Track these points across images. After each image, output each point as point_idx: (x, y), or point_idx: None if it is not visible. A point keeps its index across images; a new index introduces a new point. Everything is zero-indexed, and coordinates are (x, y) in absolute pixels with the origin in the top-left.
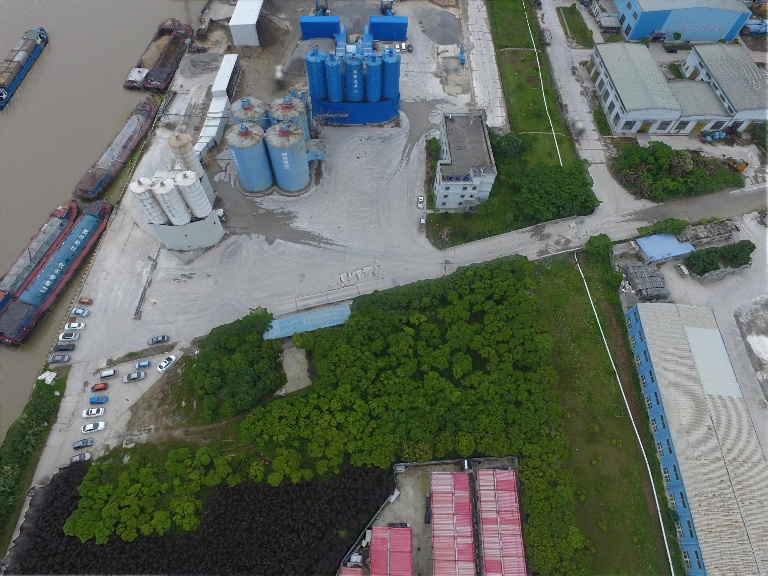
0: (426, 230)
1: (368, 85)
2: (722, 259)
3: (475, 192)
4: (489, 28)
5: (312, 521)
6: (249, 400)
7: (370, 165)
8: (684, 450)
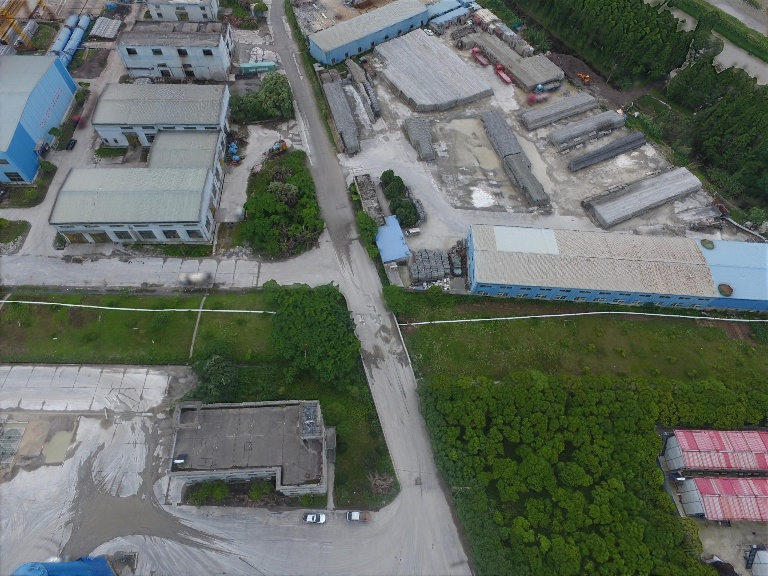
0: (365, 511)
1: None
2: None
3: None
4: None
5: None
6: None
7: None
8: (611, 284)
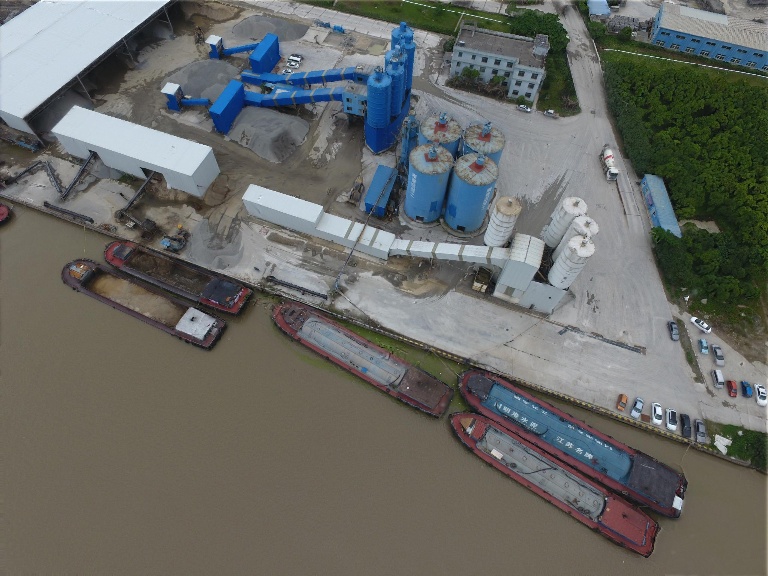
0: None
1: (408, 72)
2: None
3: None
4: (293, 2)
5: None
6: None
7: None
8: (766, 47)
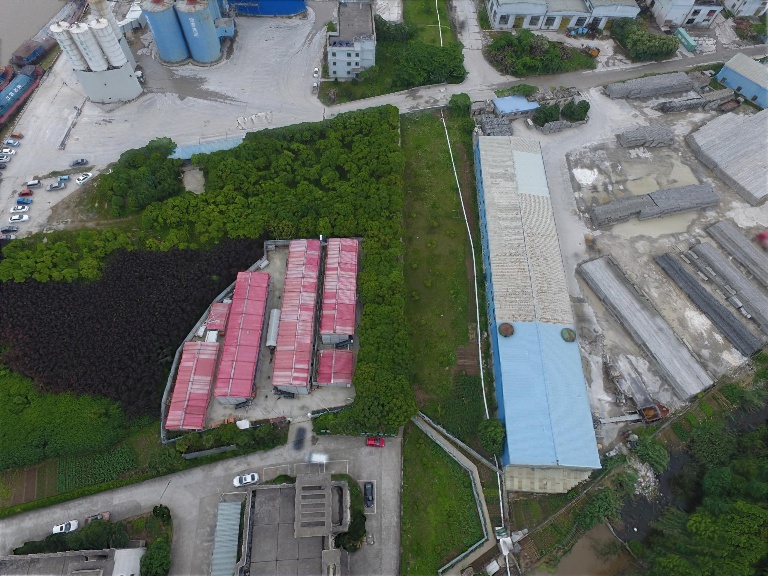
0: (318, 93)
1: None
2: (564, 117)
3: (359, 59)
4: None
5: (192, 271)
6: (148, 194)
7: (276, 46)
8: (494, 228)
